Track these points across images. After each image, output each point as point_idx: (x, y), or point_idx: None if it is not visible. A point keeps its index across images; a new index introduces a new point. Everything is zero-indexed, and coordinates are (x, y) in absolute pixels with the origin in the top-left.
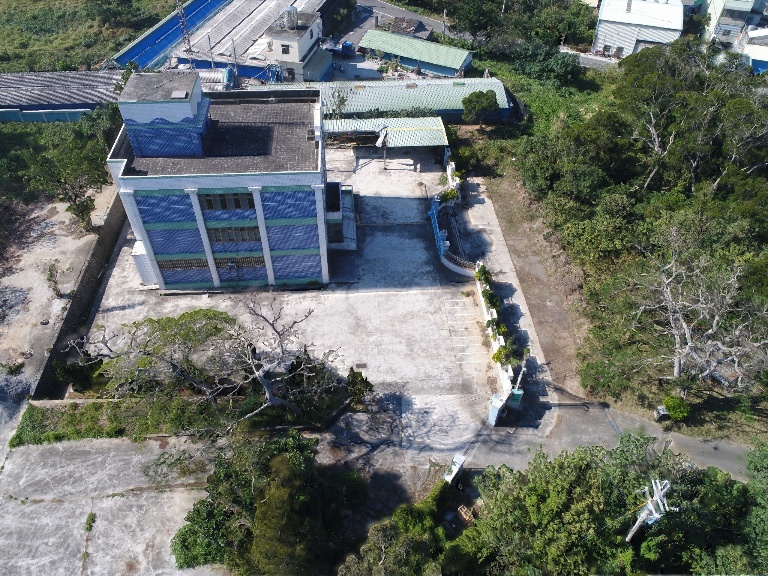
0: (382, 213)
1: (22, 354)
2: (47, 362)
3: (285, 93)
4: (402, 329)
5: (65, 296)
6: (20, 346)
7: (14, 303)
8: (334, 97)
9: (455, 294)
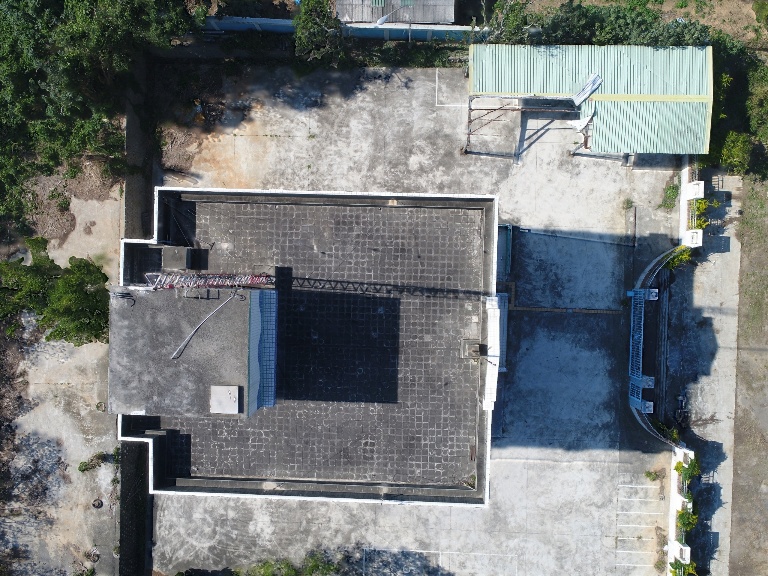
0: (553, 282)
1: (87, 557)
2: (120, 566)
3: (420, 197)
4: (554, 531)
5: (109, 459)
6: (80, 542)
7: (48, 468)
8: (503, 8)
9: (637, 474)
